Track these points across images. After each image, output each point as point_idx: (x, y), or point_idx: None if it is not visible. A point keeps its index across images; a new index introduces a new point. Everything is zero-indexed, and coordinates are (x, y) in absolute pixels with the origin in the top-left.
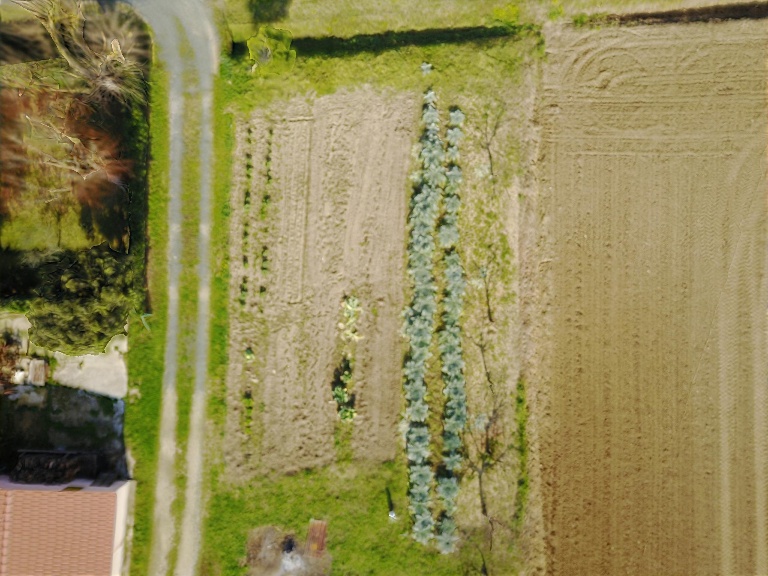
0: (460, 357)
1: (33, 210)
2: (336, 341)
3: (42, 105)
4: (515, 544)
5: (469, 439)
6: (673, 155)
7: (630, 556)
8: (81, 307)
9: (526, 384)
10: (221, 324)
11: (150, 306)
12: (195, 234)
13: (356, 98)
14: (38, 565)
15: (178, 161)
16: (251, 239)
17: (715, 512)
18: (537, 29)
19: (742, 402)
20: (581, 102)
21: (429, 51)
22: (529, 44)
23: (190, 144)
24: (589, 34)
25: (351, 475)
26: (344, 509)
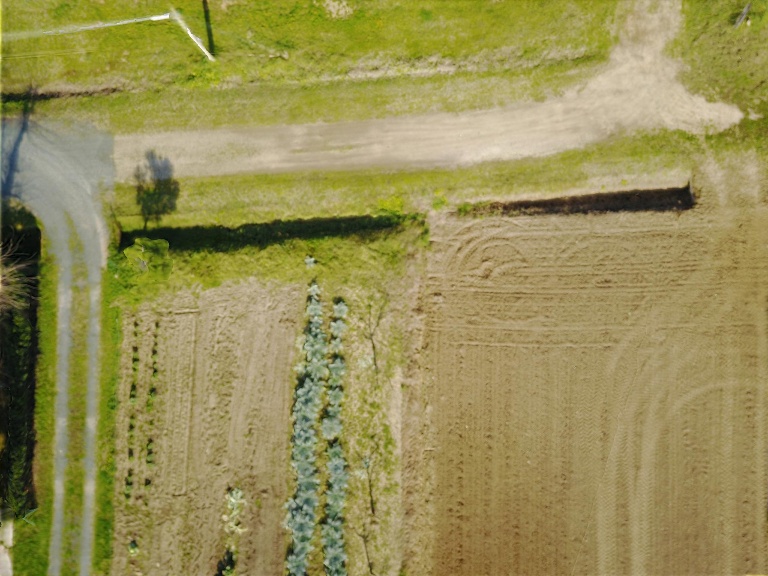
0: (341, 550)
1: None
2: (220, 533)
3: None
4: None
5: None
6: (552, 347)
7: None
8: None
9: (408, 574)
10: (106, 517)
11: (36, 500)
12: (80, 428)
13: (241, 290)
14: None
15: (64, 355)
16: (136, 432)
17: None
18: (421, 218)
19: None
20: (464, 291)
21: (312, 244)
22: (413, 234)
23: (76, 338)
24: (472, 223)
25: None
26: None
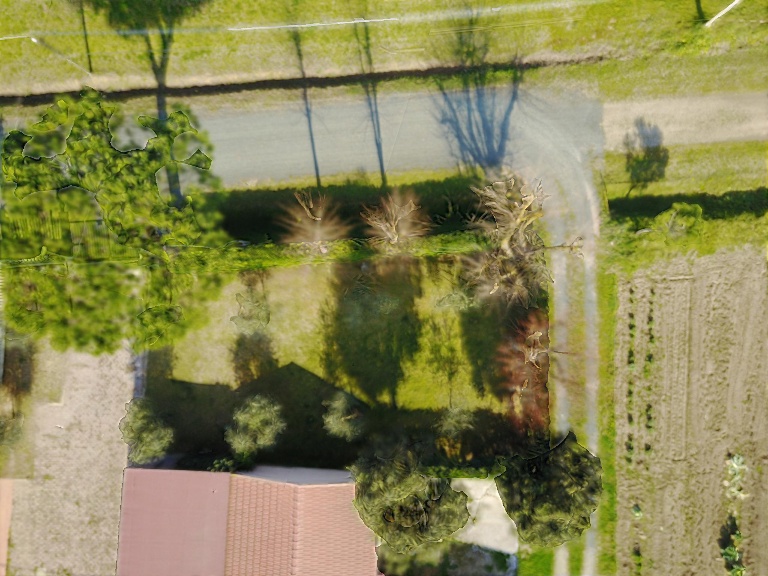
0: None
1: (424, 369)
2: (721, 498)
3: (430, 267)
4: None
5: None
6: None
7: None
8: (582, 511)
9: None
10: (608, 481)
11: None
12: (581, 392)
13: (735, 257)
14: None
15: (562, 320)
16: (635, 397)
17: None
18: None
19: None
20: None
21: None
22: None
23: (574, 304)
24: None
25: None
26: None
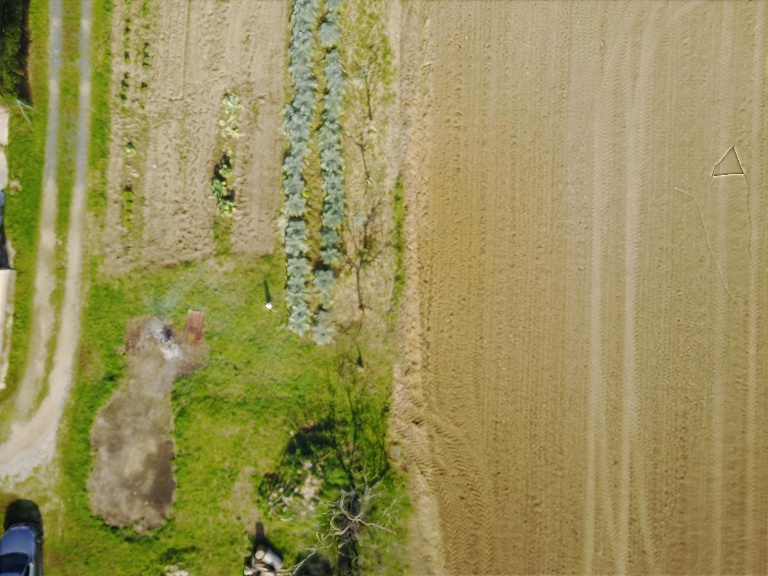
0: (339, 154)
1: None
2: (217, 138)
3: None
4: (390, 337)
5: (348, 236)
6: None
7: (502, 349)
8: None
9: (405, 184)
10: (102, 119)
11: (31, 100)
12: (76, 28)
13: None
14: None
15: None
16: (133, 35)
17: (586, 307)
18: None
19: (615, 201)
20: None
21: None
22: None
23: None
24: None
25: (230, 269)
26: (222, 301)
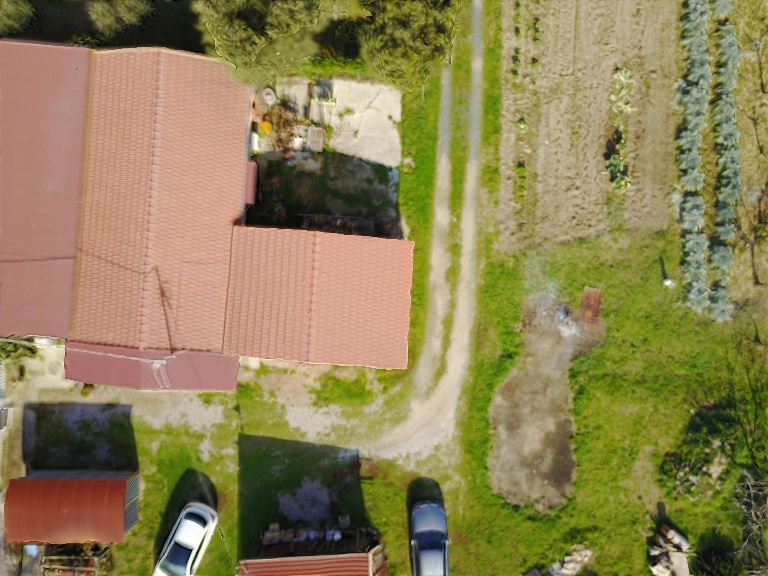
0: (736, 127)
1: None
2: (608, 113)
3: None
4: None
5: (742, 211)
6: None
7: None
8: (436, 10)
9: None
10: (494, 95)
11: None
12: (468, 5)
13: None
14: (344, 306)
15: None
16: (523, 11)
17: None
18: None
19: None
20: None
21: None
22: None
23: None
24: None
25: (624, 245)
26: (618, 277)
